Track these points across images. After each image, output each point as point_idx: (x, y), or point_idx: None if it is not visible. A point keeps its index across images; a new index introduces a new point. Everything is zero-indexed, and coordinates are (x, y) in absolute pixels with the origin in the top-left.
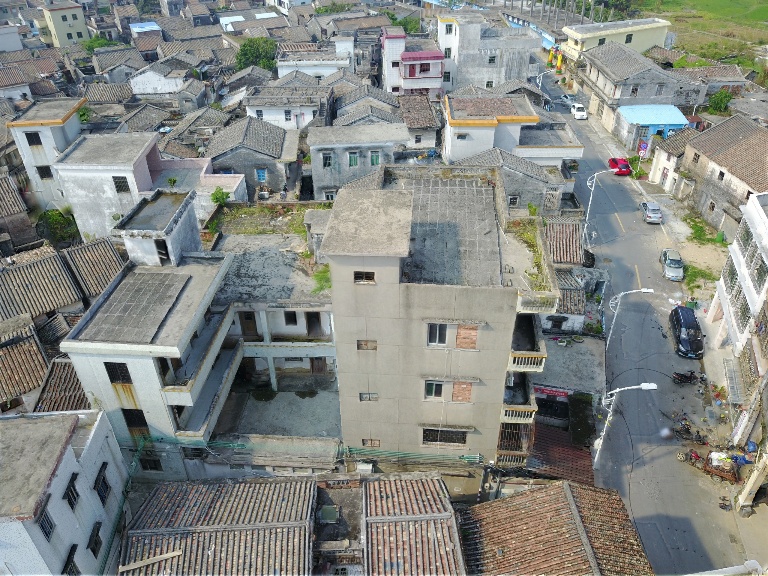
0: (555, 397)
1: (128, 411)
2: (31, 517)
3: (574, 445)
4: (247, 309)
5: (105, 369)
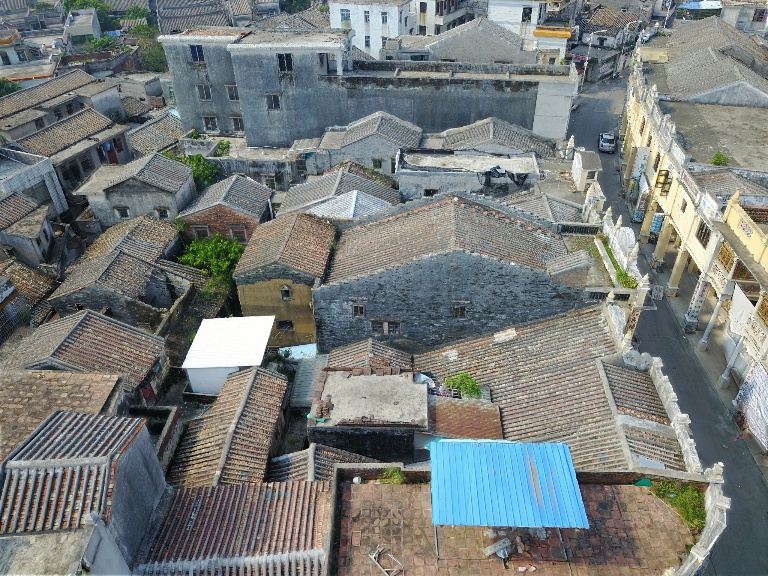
0: (584, 61)
1: (421, 27)
2: (401, 6)
3: (578, 67)
4: (471, 11)
5: (420, 5)
